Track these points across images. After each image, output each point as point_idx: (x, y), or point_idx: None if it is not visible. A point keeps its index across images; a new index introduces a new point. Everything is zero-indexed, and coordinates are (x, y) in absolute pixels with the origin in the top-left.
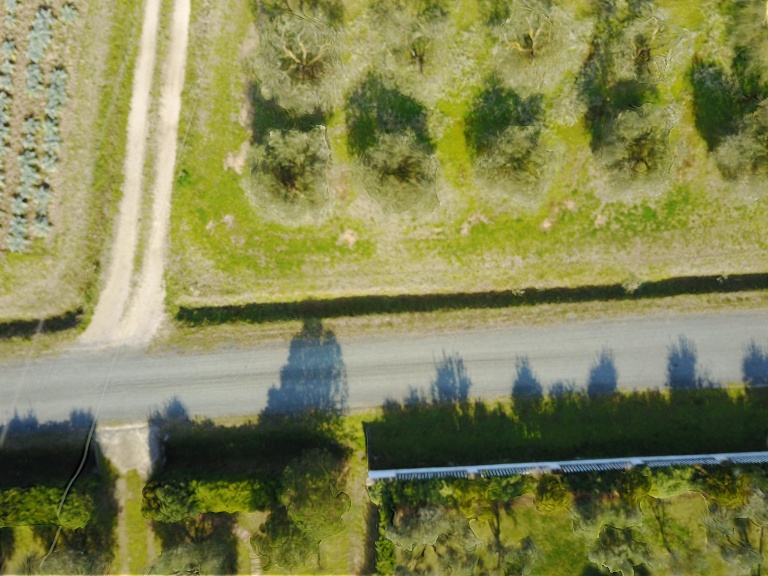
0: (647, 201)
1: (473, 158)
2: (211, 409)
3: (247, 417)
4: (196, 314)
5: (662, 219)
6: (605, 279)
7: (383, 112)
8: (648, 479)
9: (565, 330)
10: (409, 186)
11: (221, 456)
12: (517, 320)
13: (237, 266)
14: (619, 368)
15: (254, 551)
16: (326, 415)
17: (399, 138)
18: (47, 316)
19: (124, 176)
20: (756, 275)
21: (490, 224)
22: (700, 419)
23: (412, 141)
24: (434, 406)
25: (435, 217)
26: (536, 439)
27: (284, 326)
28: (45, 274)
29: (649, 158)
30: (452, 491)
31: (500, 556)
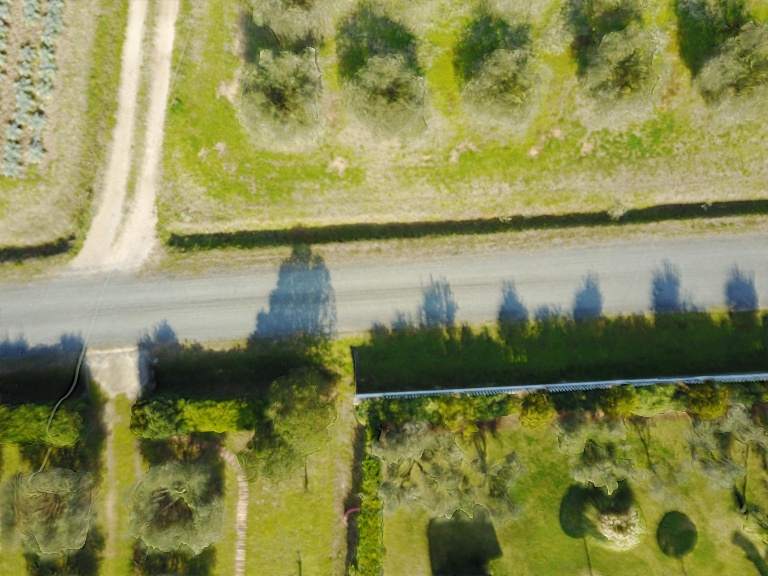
0: (632, 129)
1: (461, 87)
2: (201, 333)
3: (236, 341)
4: (187, 241)
5: (647, 147)
6: (591, 206)
7: (372, 41)
8: (632, 392)
9: (551, 255)
10: (396, 105)
11: (210, 381)
12: (504, 246)
13: (228, 193)
14: (605, 293)
15: (241, 466)
16: (315, 339)
17: (387, 60)
18: (40, 242)
19: (118, 103)
20: (740, 203)
21: (477, 152)
22: (685, 343)
23: (400, 64)
24: (422, 331)
25: (423, 145)
26: (523, 363)
27: (274, 251)
28: (39, 200)
29: (633, 80)
30: (438, 406)
31: (486, 476)
